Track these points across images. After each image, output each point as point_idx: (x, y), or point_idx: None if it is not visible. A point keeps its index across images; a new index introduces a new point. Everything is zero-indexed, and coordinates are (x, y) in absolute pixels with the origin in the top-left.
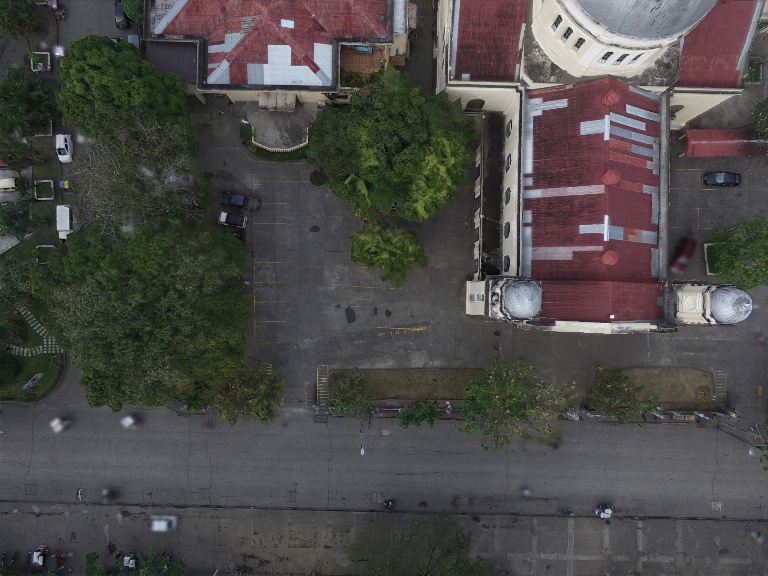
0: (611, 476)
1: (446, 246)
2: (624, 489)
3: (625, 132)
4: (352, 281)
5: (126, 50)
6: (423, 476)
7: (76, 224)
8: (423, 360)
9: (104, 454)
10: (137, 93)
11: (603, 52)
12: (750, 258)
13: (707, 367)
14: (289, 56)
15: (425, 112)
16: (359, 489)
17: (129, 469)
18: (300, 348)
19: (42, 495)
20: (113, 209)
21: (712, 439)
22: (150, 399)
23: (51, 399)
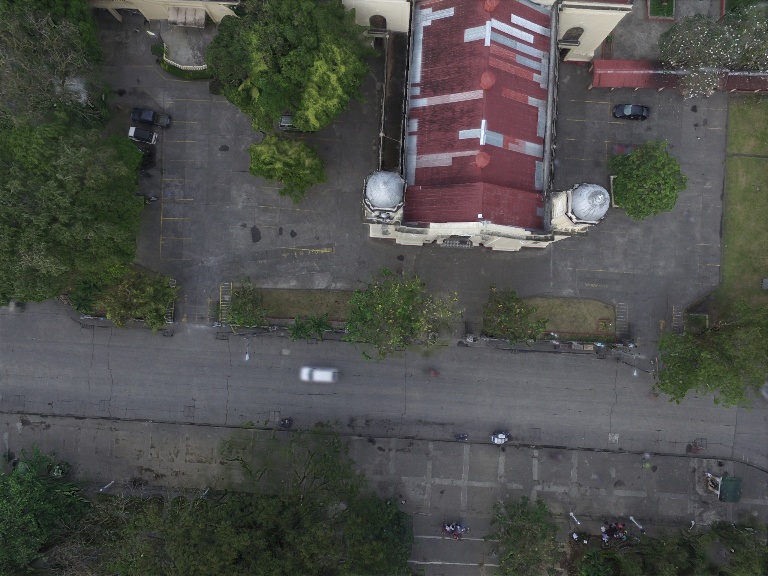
0: (509, 404)
1: (353, 170)
2: (521, 417)
3: (509, 41)
4: (259, 201)
5: None
6: (321, 396)
7: None
8: (326, 282)
9: (7, 363)
10: None
11: None
12: (643, 181)
13: (609, 299)
14: None
15: (314, 17)
16: (257, 407)
17: (31, 378)
18: (205, 265)
19: None
20: None
21: (612, 371)
22: (30, 289)
23: None
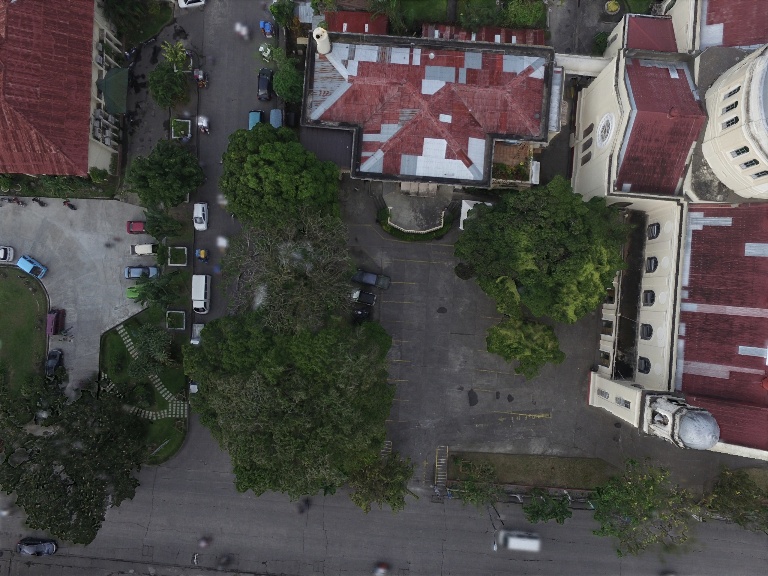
0: (724, 575)
1: (572, 335)
2: None
3: None
4: (476, 364)
5: None
6: (536, 563)
7: (230, 308)
8: (542, 447)
9: (222, 521)
10: (305, 188)
11: None
12: None
13: None
14: (444, 150)
15: (587, 221)
16: (472, 571)
17: (246, 537)
18: (421, 428)
19: (159, 557)
20: (282, 306)
21: None
22: (301, 491)
23: (172, 463)
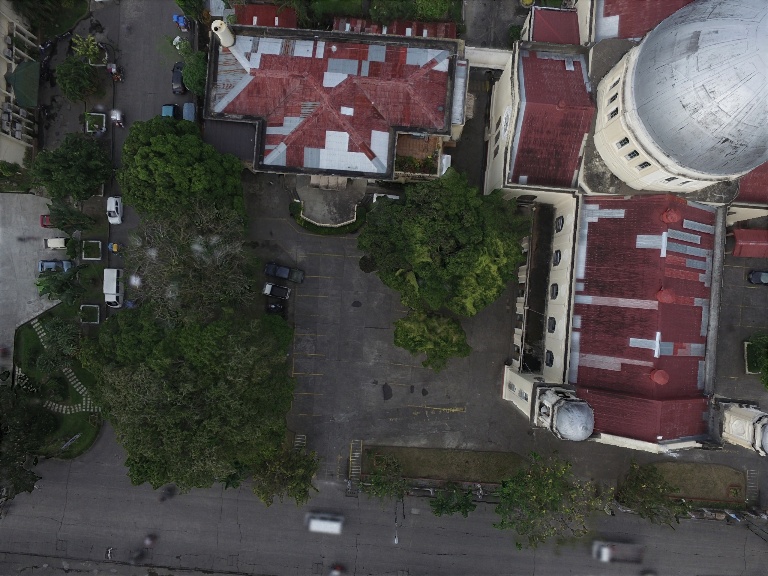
0: (638, 569)
1: (486, 329)
2: None
3: (681, 247)
4: (391, 358)
5: (187, 131)
6: (450, 557)
7: (128, 300)
8: (457, 441)
9: (136, 515)
10: (198, 180)
11: (668, 177)
12: None
13: (740, 465)
14: (346, 142)
15: (481, 213)
16: (386, 566)
17: (159, 531)
18: (335, 422)
19: (72, 551)
20: (170, 297)
21: (741, 538)
22: (193, 483)
23: (87, 457)
